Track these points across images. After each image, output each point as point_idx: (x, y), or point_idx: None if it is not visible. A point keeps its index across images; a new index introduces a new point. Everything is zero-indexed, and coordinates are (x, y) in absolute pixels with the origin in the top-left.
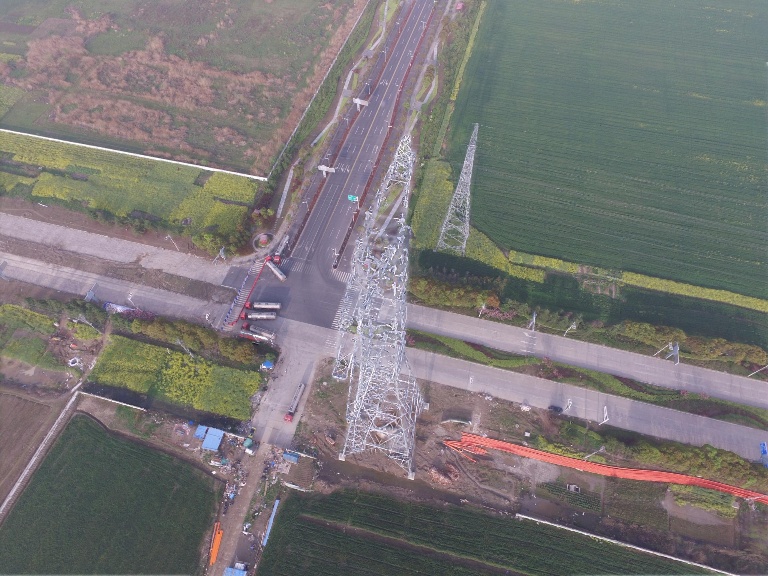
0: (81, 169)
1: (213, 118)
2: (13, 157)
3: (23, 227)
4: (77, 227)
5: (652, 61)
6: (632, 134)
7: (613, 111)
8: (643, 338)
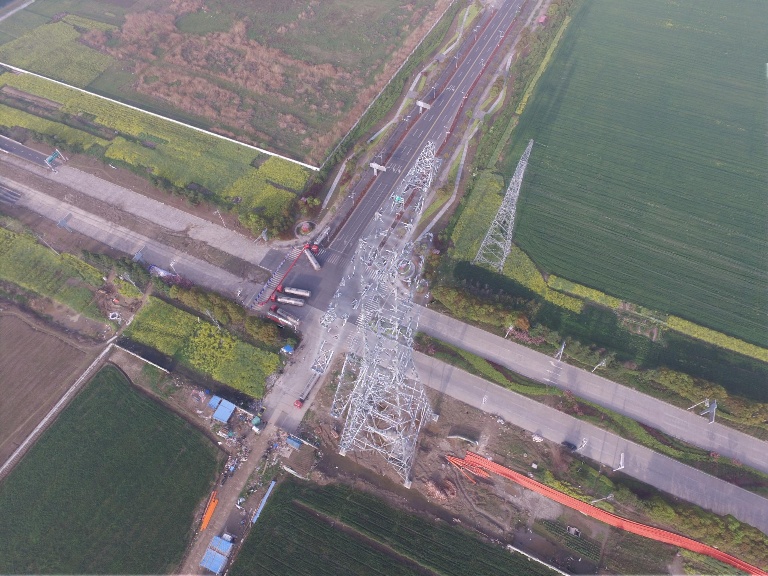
0: (152, 138)
1: (279, 104)
2: (95, 119)
3: (92, 184)
4: (139, 191)
5: (743, 97)
6: (706, 172)
7: (689, 145)
8: (678, 389)
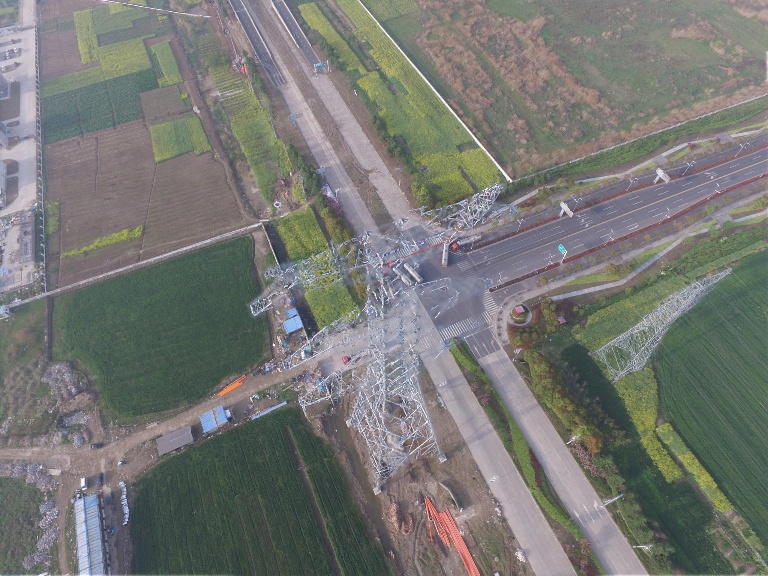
0: (399, 84)
1: (522, 106)
2: (370, 50)
3: (333, 99)
4: (359, 122)
5: None
6: None
7: None
8: None
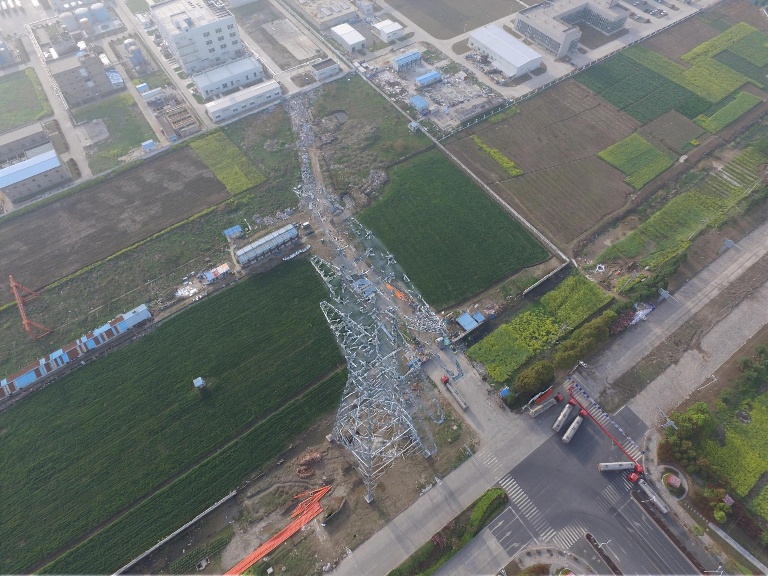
0: None
1: None
2: None
3: None
4: None
5: None
6: None
7: None
8: None
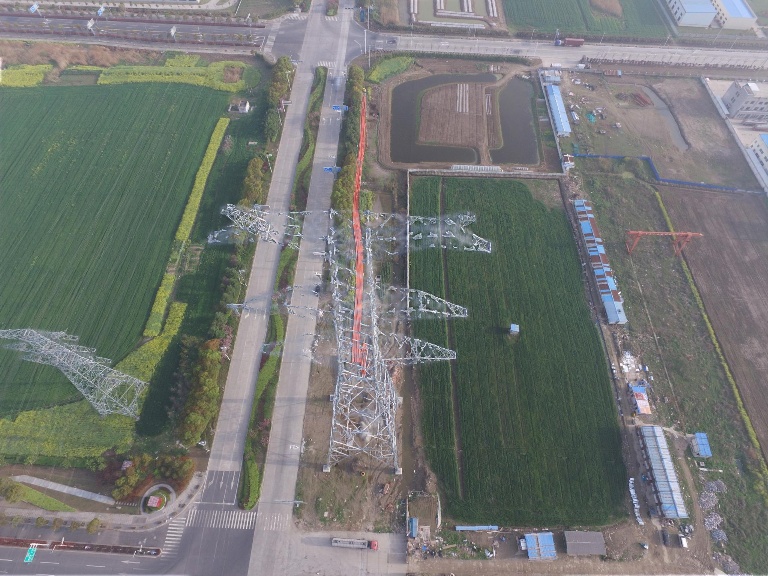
0: None
1: None
2: None
3: None
4: None
5: None
6: None
7: None
8: None
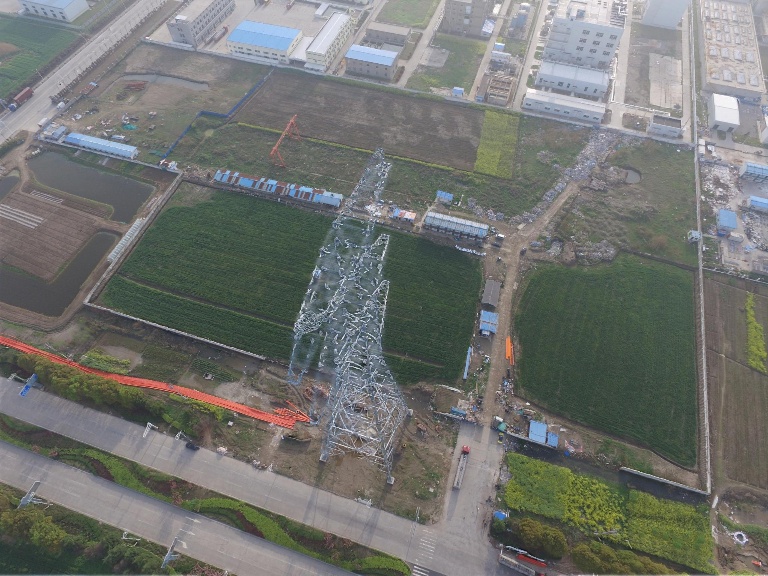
0: None
1: None
2: None
3: None
4: None
5: None
6: None
7: None
8: None
